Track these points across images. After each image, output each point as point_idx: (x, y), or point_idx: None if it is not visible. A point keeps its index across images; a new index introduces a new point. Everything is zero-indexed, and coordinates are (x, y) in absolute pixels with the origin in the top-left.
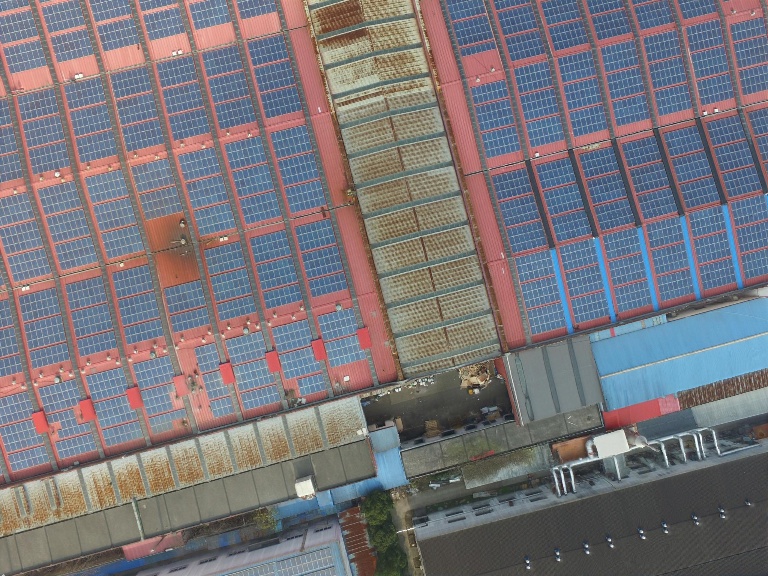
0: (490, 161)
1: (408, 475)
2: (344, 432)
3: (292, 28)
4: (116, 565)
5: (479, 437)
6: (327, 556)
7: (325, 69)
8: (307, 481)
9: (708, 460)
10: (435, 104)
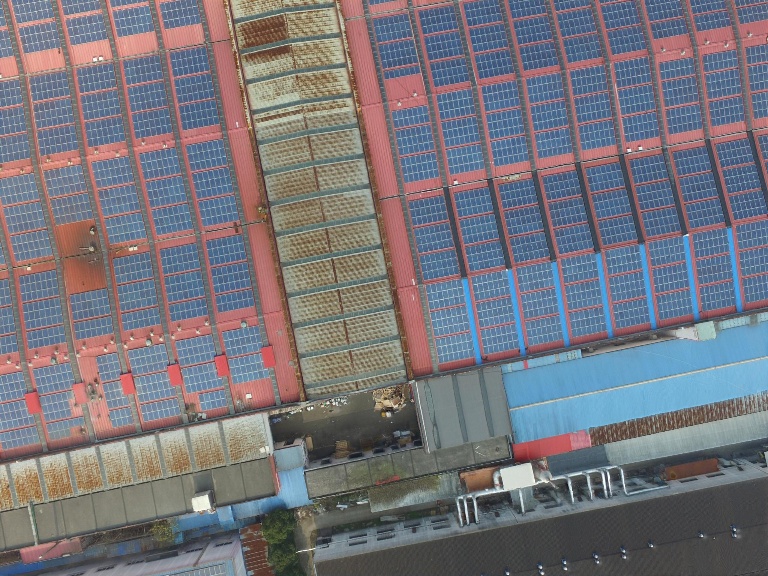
0: (408, 186)
1: (311, 495)
2: (247, 449)
3: (216, 41)
4: (14, 567)
5: (385, 461)
6: (221, 572)
7: (246, 84)
8: (204, 496)
9: (614, 499)
10: (355, 125)
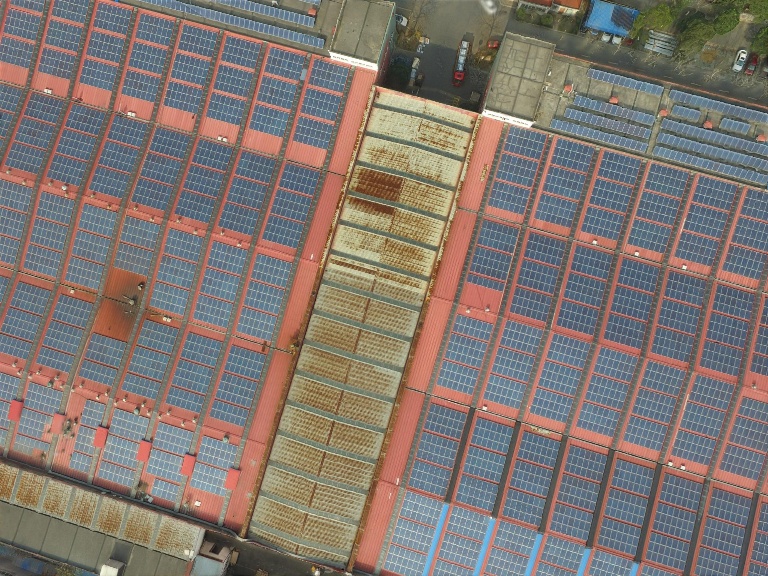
0: (438, 388)
1: None
2: (174, 543)
3: (332, 171)
4: None
5: None
6: None
7: (339, 223)
8: (115, 569)
9: None
10: (418, 309)
